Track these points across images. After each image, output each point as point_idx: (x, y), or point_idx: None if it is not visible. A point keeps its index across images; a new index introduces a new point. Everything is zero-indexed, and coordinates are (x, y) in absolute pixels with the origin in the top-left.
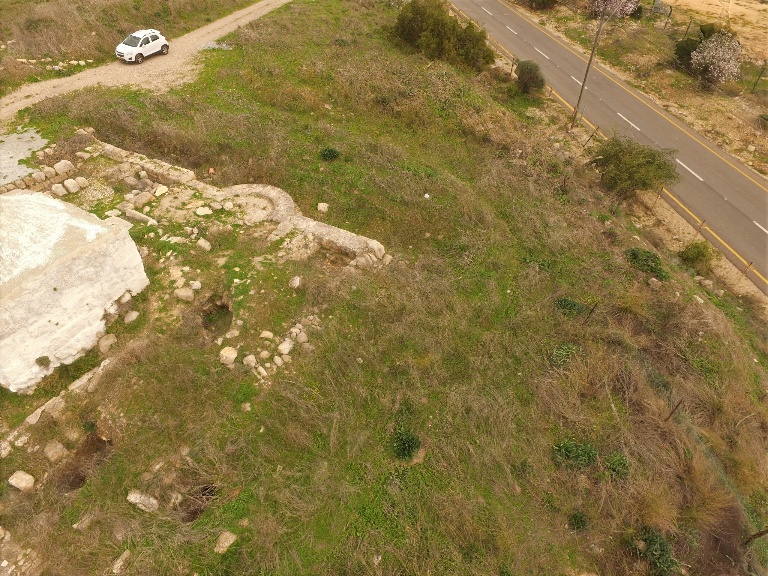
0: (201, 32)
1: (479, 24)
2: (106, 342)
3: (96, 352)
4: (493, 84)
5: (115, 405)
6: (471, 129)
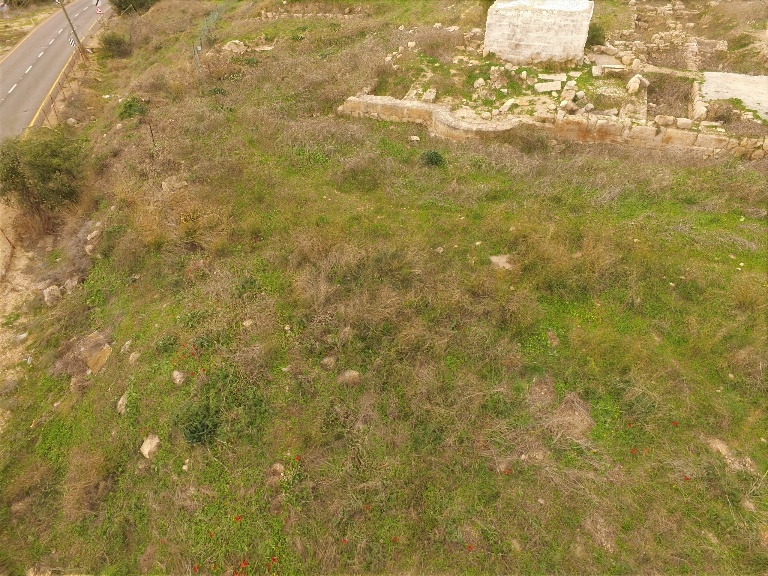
0: None
1: None
2: (481, 52)
3: None
4: None
5: None
6: None
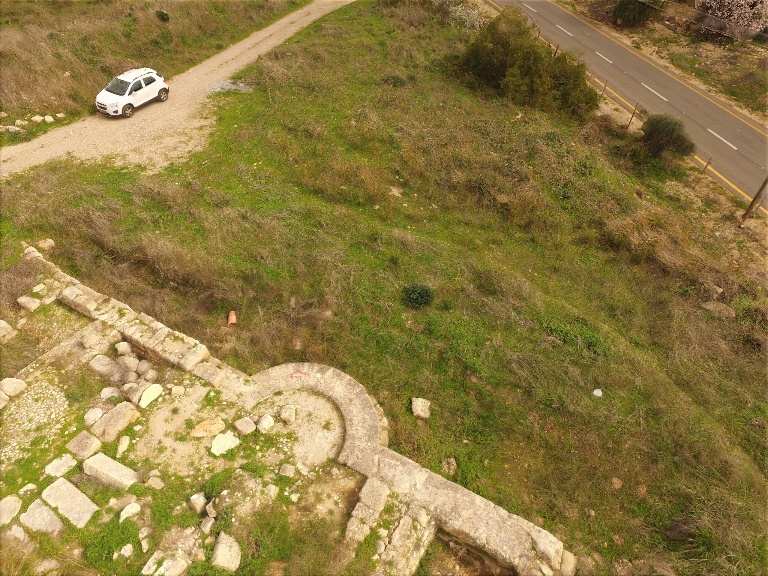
0: (211, 64)
1: (561, 49)
2: None
3: None
4: (604, 140)
5: None
6: (624, 241)
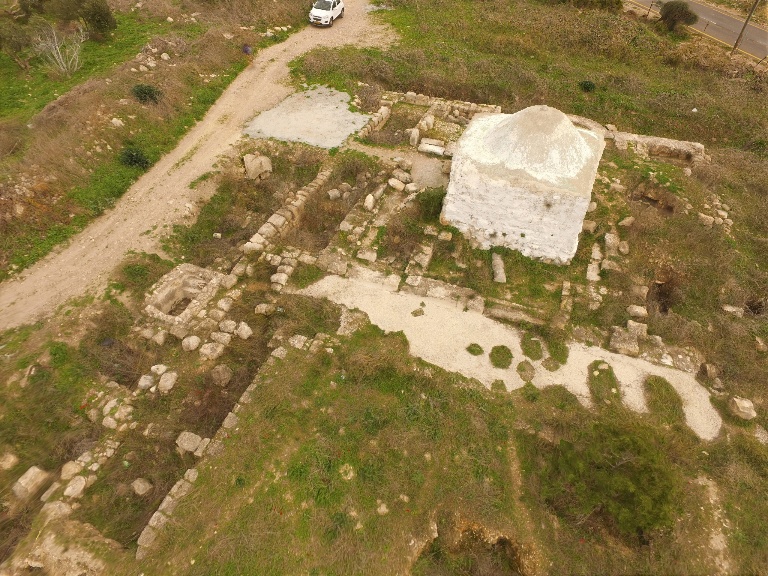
0: None
1: None
2: (592, 225)
3: (586, 233)
4: None
5: (668, 255)
6: (679, 58)
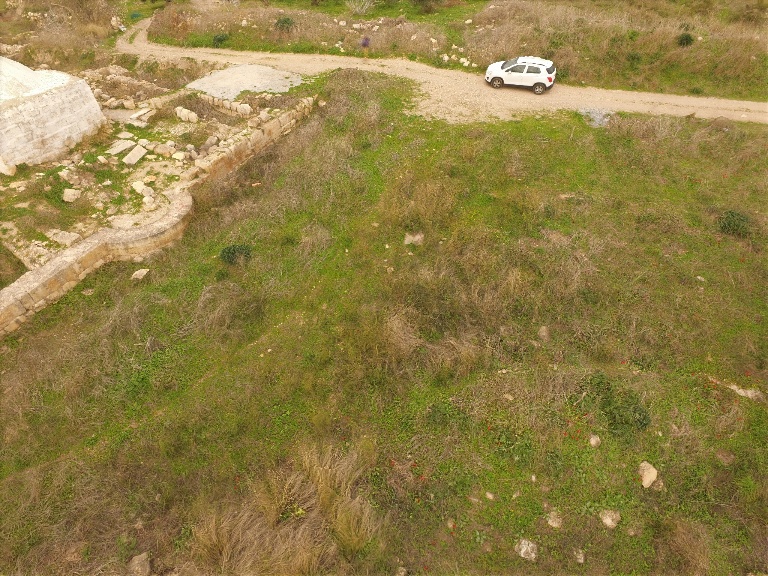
0: (645, 97)
1: None
2: None
3: None
4: None
5: None
6: (296, 461)
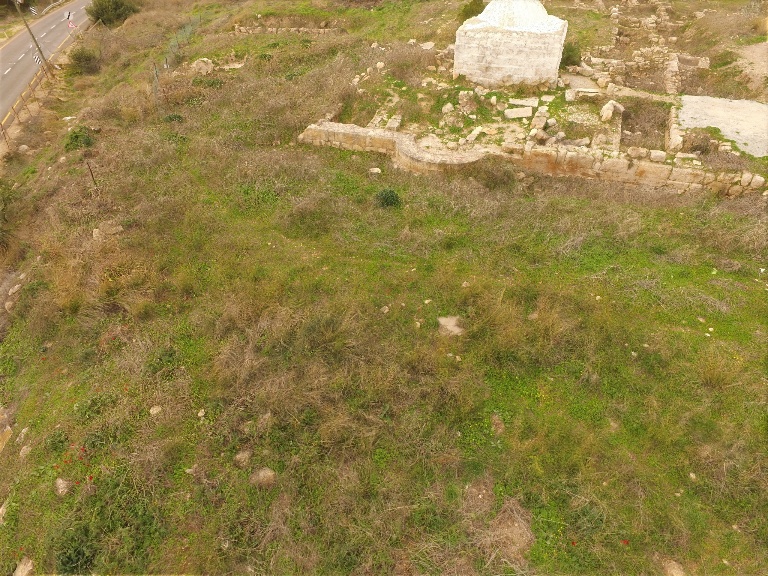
0: None
1: None
2: None
3: None
4: None
5: None
6: None
